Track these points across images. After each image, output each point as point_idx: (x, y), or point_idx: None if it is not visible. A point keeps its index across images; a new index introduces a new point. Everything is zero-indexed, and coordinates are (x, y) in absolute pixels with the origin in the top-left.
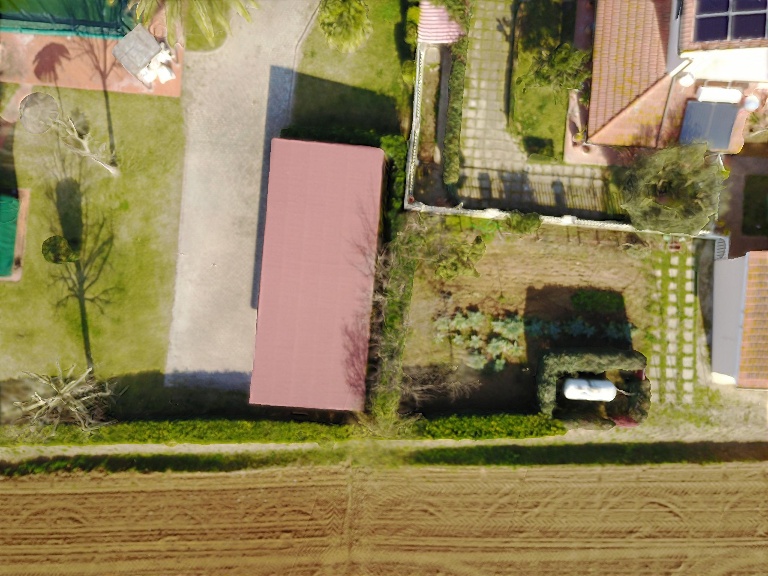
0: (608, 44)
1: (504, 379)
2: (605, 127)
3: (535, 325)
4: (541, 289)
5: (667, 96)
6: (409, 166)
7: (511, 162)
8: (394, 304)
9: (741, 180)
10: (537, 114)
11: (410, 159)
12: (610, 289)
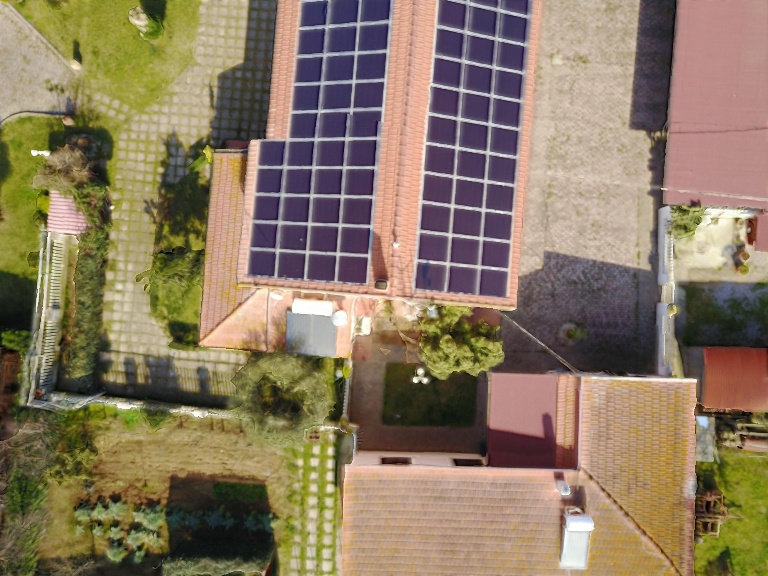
0: (218, 247)
1: (146, 570)
2: (213, 332)
3: (175, 516)
4: (184, 477)
5: (266, 305)
6: (36, 359)
7: (157, 347)
8: (15, 504)
9: (383, 368)
10: (183, 298)
11: (39, 351)
12: (254, 477)
